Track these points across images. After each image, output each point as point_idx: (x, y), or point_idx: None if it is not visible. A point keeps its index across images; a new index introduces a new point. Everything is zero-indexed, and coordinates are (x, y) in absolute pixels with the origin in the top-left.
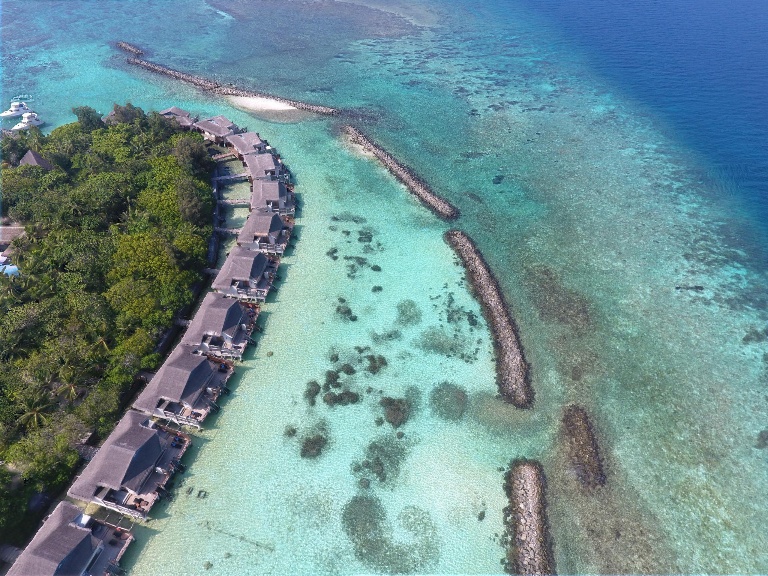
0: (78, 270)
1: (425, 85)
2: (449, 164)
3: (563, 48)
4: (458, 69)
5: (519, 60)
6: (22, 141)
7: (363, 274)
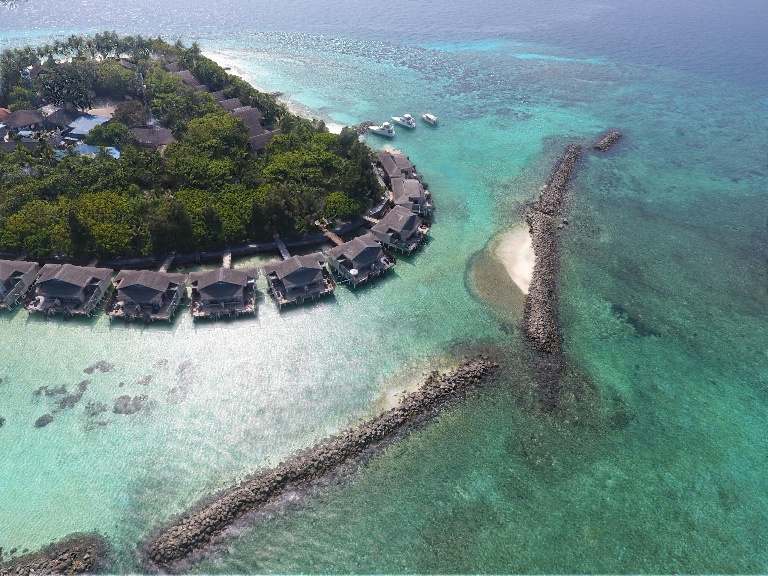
0: None
1: None
2: (385, 572)
3: None
4: None
5: None
6: None
7: (38, 404)
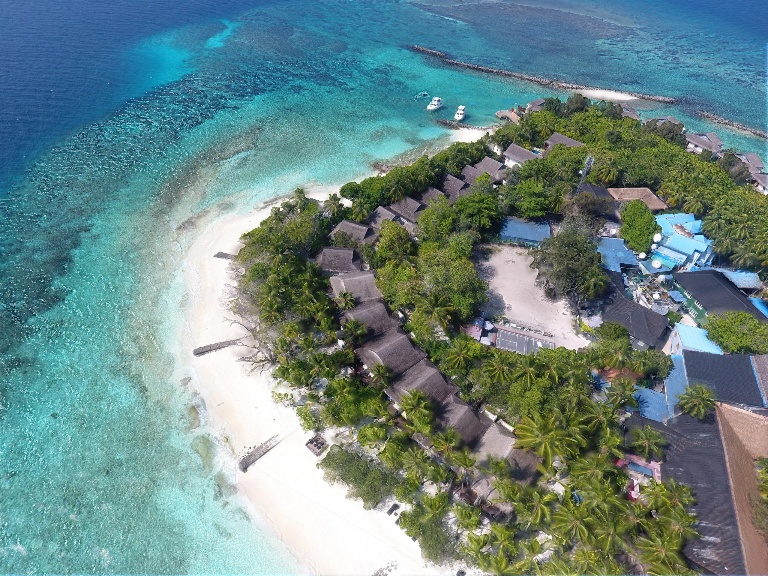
0: (759, 213)
1: (705, 77)
2: None
3: (766, 43)
4: (711, 63)
5: (747, 54)
6: (534, 126)
7: None
